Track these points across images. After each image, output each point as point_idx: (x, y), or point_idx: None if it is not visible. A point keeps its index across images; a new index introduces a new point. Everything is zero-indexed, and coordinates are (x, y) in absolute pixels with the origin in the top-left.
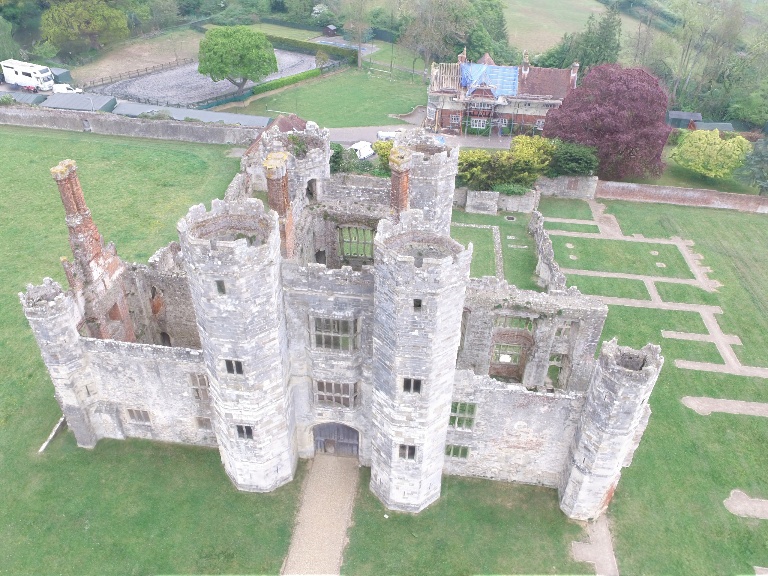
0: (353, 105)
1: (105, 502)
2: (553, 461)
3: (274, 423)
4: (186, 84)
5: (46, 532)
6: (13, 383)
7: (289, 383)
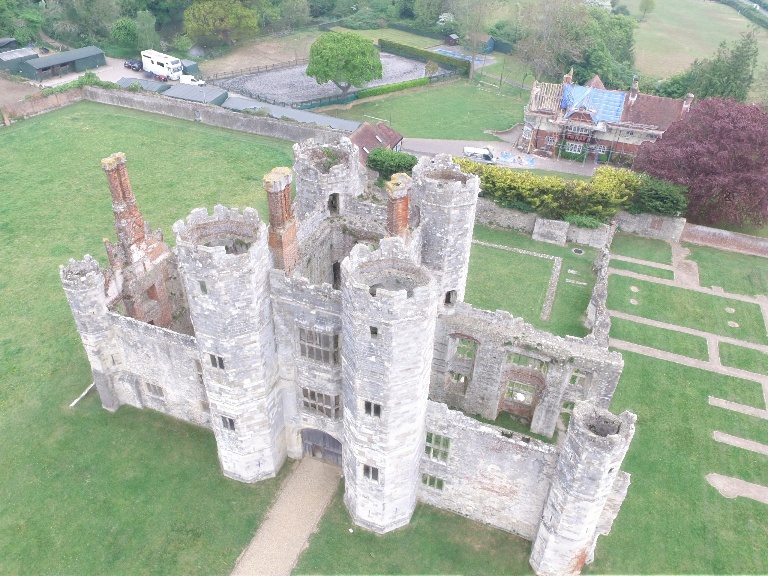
0: (452, 117)
1: (109, 462)
2: (528, 512)
3: (256, 420)
4: (298, 83)
5: (54, 478)
6: (68, 341)
7: (276, 385)
